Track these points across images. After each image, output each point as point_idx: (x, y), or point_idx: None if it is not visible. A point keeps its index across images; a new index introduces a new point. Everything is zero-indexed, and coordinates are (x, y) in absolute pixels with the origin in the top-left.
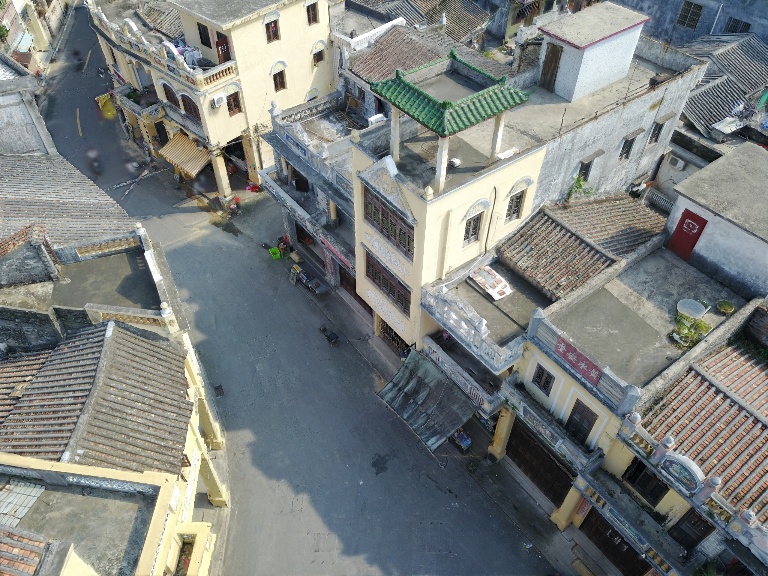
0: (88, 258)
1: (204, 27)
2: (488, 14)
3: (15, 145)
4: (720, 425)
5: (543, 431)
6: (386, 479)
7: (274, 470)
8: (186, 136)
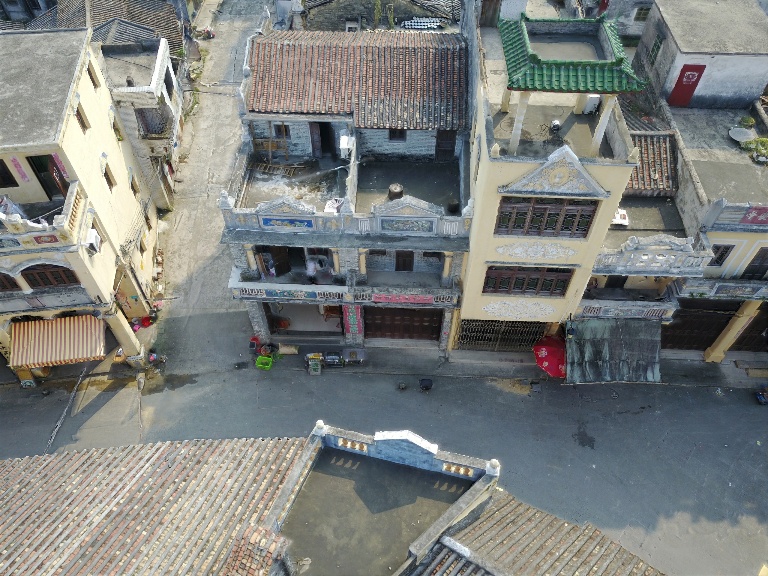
0: (284, 518)
1: None
2: (170, 4)
3: None
4: None
5: (741, 292)
6: (602, 445)
7: None
8: (31, 321)
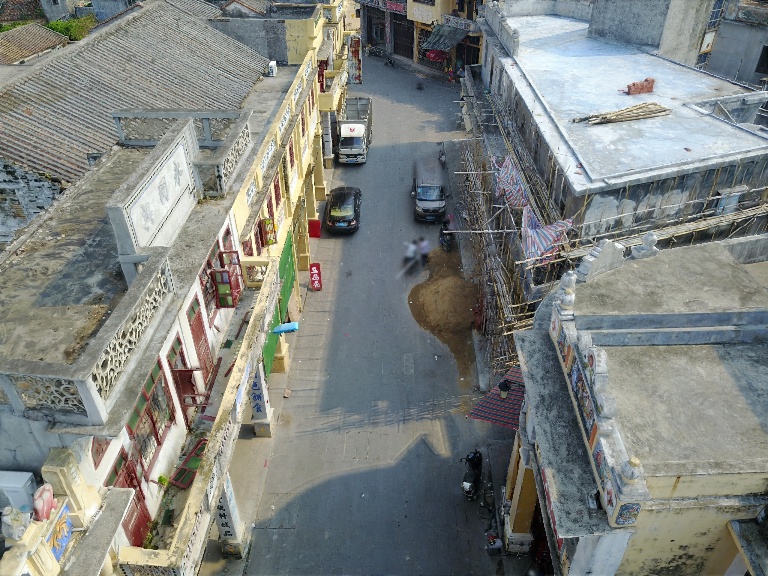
0: None
1: None
2: None
3: None
4: None
5: None
6: (424, 91)
7: None
8: None
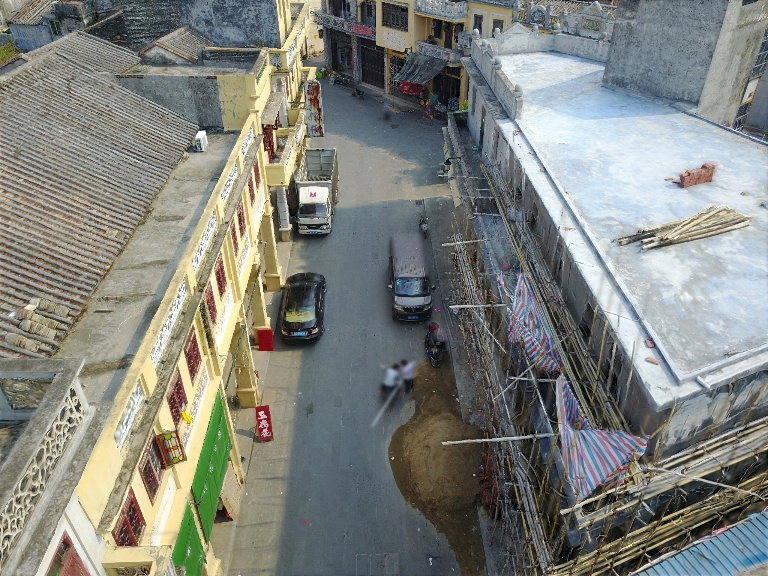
0: None
1: None
2: None
3: None
4: (557, 7)
5: None
6: (399, 129)
7: (333, 130)
8: None
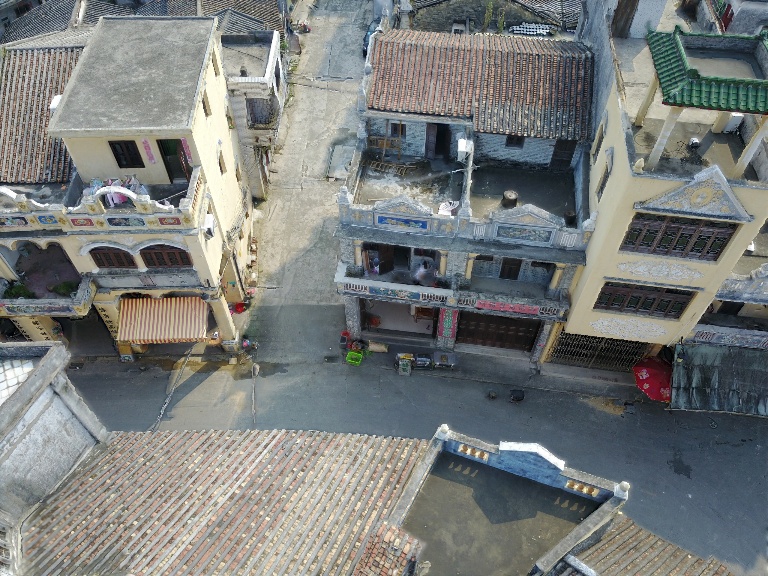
0: (403, 518)
1: (126, 143)
2: None
3: (58, 467)
4: None
5: None
6: (699, 475)
7: None
8: (140, 299)
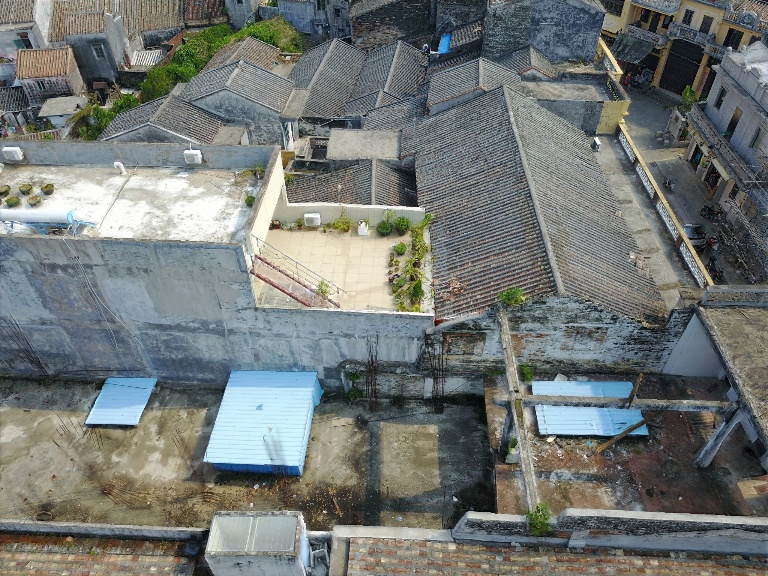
0: None
1: None
2: None
3: None
4: (760, 10)
5: (689, 36)
6: None
7: None
8: None
